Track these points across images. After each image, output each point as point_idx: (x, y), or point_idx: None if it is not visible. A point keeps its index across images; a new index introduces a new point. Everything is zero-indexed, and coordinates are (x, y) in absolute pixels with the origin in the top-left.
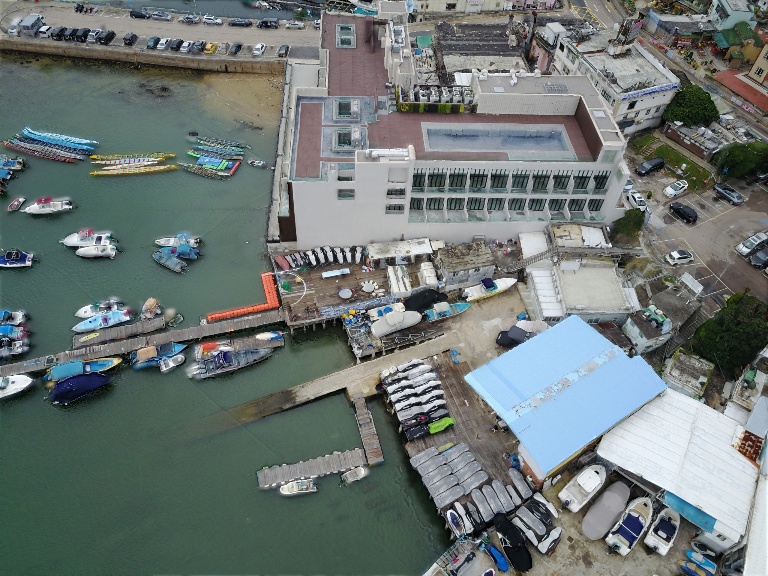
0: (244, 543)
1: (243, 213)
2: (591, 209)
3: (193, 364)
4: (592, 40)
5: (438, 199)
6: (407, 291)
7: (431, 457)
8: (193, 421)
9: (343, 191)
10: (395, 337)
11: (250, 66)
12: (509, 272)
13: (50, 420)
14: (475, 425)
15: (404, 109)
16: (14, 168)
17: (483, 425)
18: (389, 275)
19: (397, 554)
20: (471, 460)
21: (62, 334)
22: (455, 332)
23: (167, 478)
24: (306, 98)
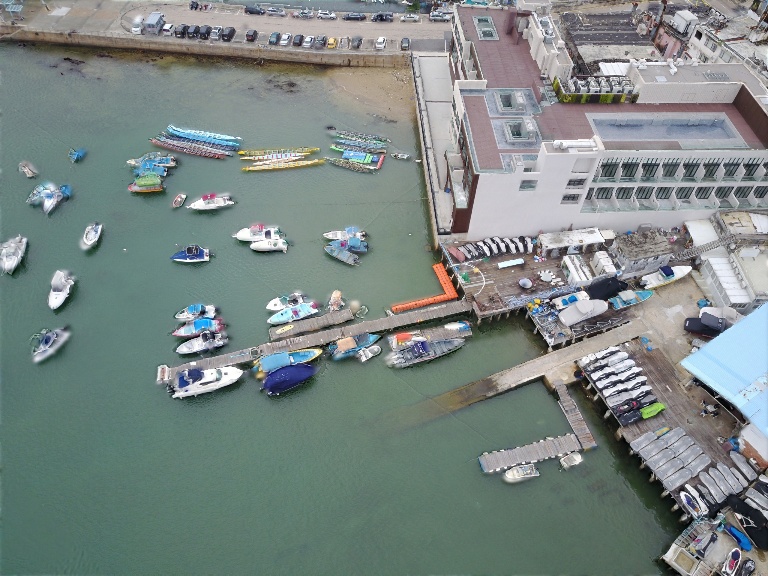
0: (480, 526)
1: (399, 206)
2: (755, 196)
3: (391, 354)
4: (729, 27)
5: (608, 189)
6: (588, 280)
7: (652, 441)
8: (402, 409)
9: (526, 182)
10: (583, 325)
11: (373, 60)
12: (682, 260)
13: (269, 410)
14: (683, 410)
15: (566, 100)
16: (168, 165)
17: (690, 410)
18: (566, 264)
19: (629, 535)
20: (691, 444)
21: (257, 327)
22: (640, 319)
23: (390, 464)
24: (465, 91)
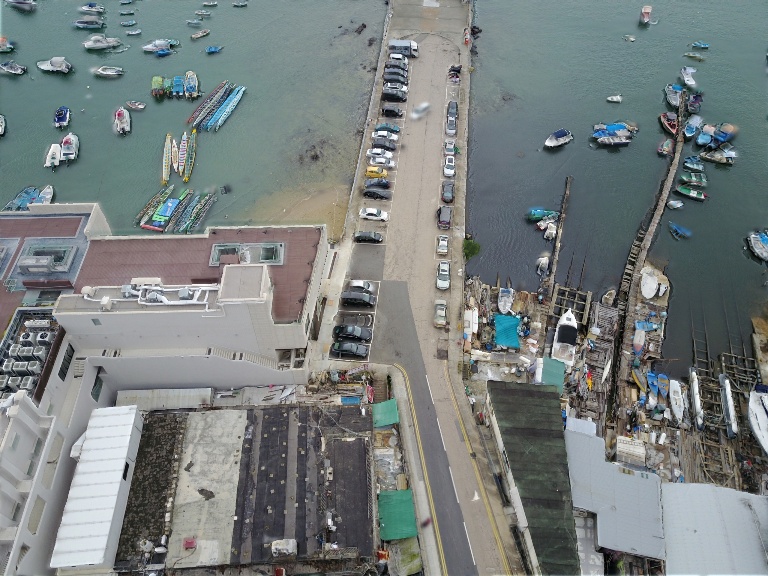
0: None
1: None
2: None
3: None
4: None
5: None
6: None
7: None
8: None
9: None
10: None
11: None
12: None
13: None
14: None
15: None
16: None
17: None
18: None
19: None
20: None
21: None
22: None
23: None
24: None
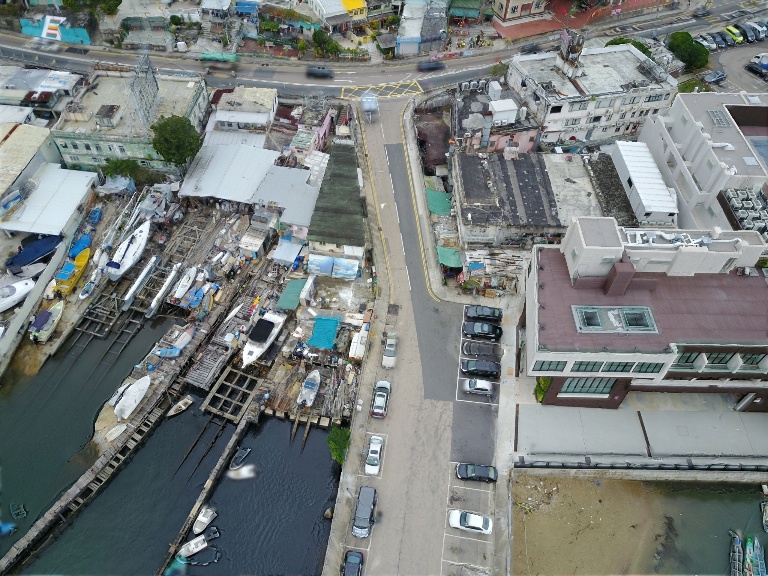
0: None
1: None
2: None
3: None
4: None
5: None
6: None
7: None
8: None
9: None
10: None
11: None
12: None
13: None
14: None
15: None
16: None
17: None
18: None
19: None
20: None
21: None
22: None
23: None
24: None
